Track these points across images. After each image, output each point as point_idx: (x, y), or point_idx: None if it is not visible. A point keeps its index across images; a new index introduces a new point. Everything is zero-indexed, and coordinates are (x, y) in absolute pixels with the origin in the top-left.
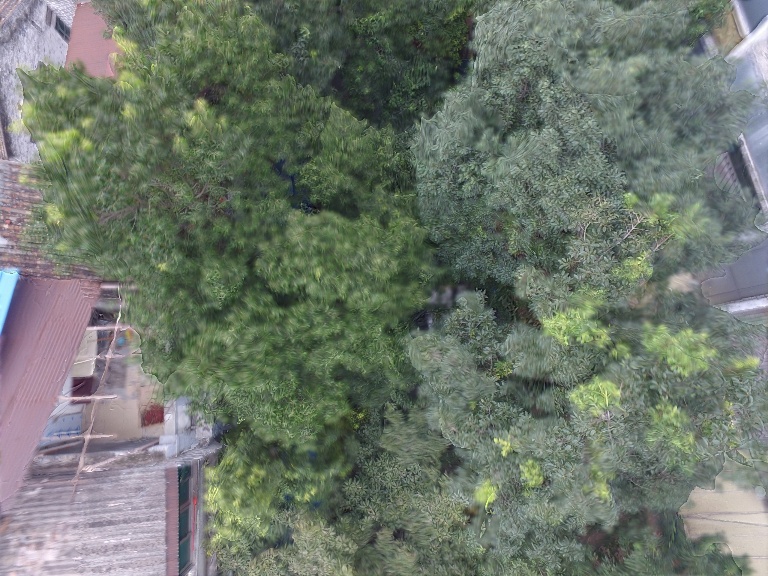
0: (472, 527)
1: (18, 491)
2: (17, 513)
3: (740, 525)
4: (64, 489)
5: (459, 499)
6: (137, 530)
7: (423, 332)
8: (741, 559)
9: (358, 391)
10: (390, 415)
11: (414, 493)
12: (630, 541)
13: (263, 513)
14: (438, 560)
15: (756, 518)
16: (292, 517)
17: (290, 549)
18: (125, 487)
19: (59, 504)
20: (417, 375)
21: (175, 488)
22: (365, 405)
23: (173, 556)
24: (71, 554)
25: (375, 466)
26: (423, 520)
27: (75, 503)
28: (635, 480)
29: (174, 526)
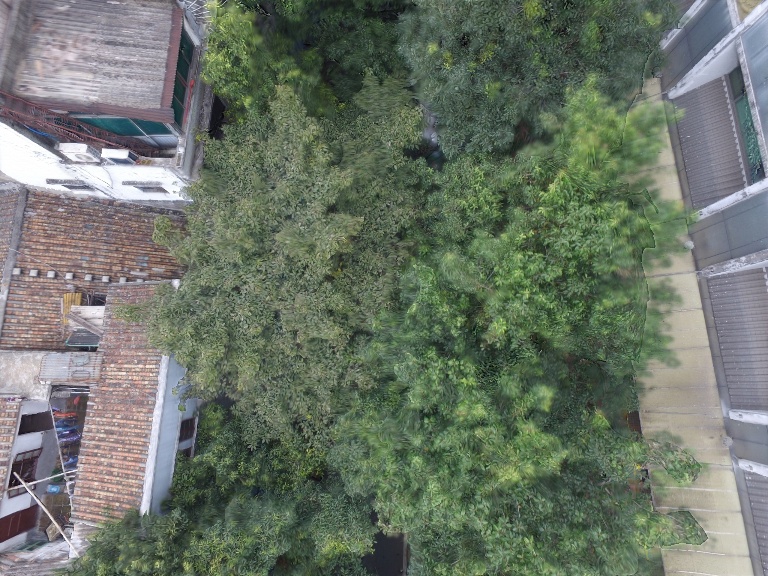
0: (424, 156)
1: (50, 4)
2: (48, 20)
3: (669, 284)
4: (88, 12)
5: (415, 112)
6: (143, 54)
7: (405, 19)
8: (666, 314)
9: (342, 82)
10: (367, 78)
11: (378, 125)
12: (553, 149)
13: (249, 48)
14: (391, 187)
15: (683, 277)
16: (272, 97)
17: (267, 143)
18: (138, 21)
19: (82, 22)
20: (395, 50)
21: (178, 32)
22: (347, 94)
23: (170, 79)
24: (88, 59)
25: (348, 125)
26: (383, 151)
27: (95, 24)
28: (564, 100)
29: (174, 59)
